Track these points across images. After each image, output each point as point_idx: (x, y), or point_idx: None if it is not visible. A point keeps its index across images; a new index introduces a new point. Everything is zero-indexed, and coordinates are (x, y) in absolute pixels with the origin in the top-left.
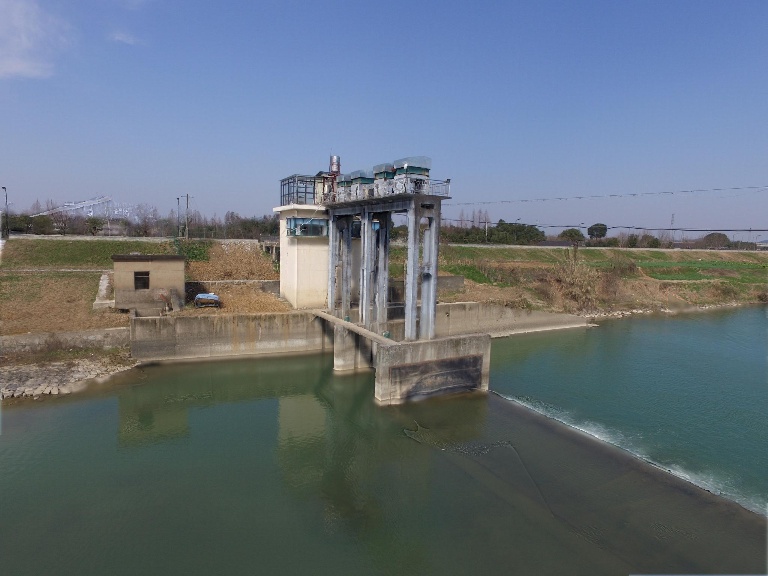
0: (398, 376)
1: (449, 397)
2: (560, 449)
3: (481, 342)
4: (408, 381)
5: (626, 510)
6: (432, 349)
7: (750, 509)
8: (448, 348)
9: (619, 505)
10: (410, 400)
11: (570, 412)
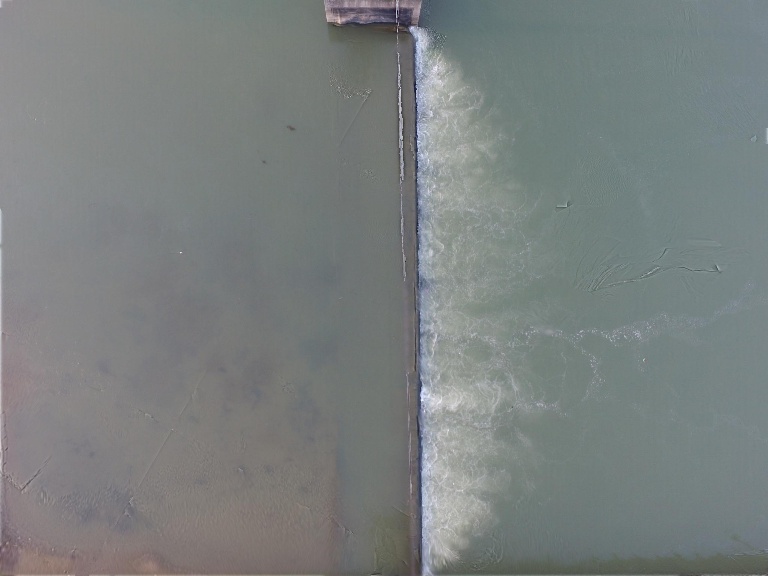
0: (339, 13)
1: (376, 31)
2: (387, 111)
3: (412, 1)
4: (347, 16)
5: (366, 160)
6: (366, 1)
7: (420, 181)
8: (380, 2)
9: (367, 156)
10: (349, 25)
11: (440, 78)
